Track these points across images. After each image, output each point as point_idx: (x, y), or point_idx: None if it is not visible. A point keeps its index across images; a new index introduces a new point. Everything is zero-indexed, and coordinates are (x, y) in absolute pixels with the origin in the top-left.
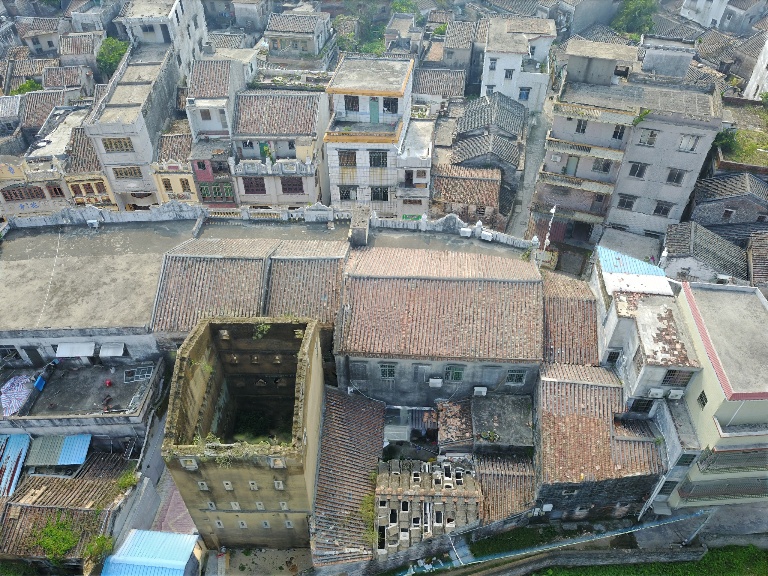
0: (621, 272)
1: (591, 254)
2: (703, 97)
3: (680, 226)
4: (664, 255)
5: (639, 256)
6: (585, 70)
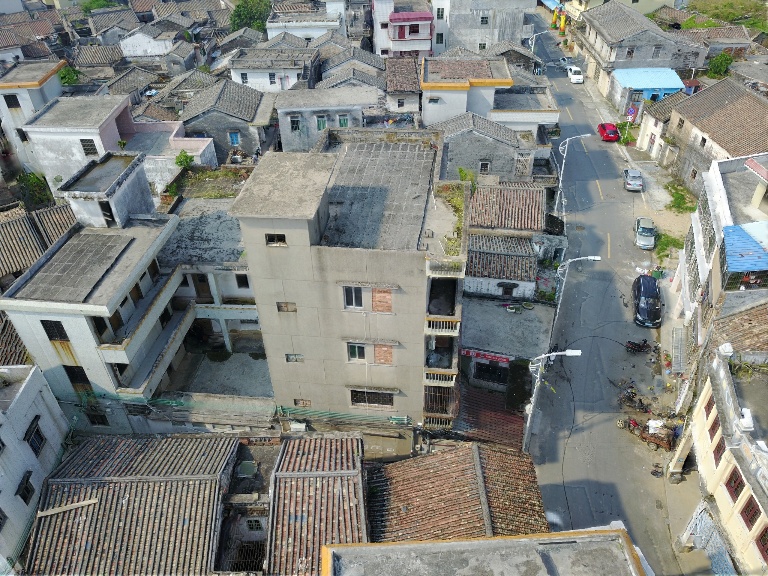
0: (767, 254)
1: (530, 360)
2: (355, 146)
3: (472, 262)
4: (599, 258)
5: (507, 316)
6: (317, 221)
